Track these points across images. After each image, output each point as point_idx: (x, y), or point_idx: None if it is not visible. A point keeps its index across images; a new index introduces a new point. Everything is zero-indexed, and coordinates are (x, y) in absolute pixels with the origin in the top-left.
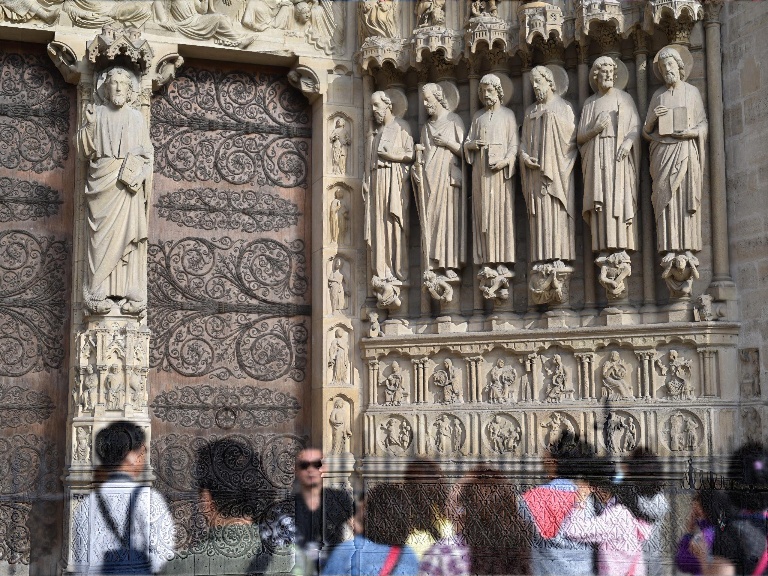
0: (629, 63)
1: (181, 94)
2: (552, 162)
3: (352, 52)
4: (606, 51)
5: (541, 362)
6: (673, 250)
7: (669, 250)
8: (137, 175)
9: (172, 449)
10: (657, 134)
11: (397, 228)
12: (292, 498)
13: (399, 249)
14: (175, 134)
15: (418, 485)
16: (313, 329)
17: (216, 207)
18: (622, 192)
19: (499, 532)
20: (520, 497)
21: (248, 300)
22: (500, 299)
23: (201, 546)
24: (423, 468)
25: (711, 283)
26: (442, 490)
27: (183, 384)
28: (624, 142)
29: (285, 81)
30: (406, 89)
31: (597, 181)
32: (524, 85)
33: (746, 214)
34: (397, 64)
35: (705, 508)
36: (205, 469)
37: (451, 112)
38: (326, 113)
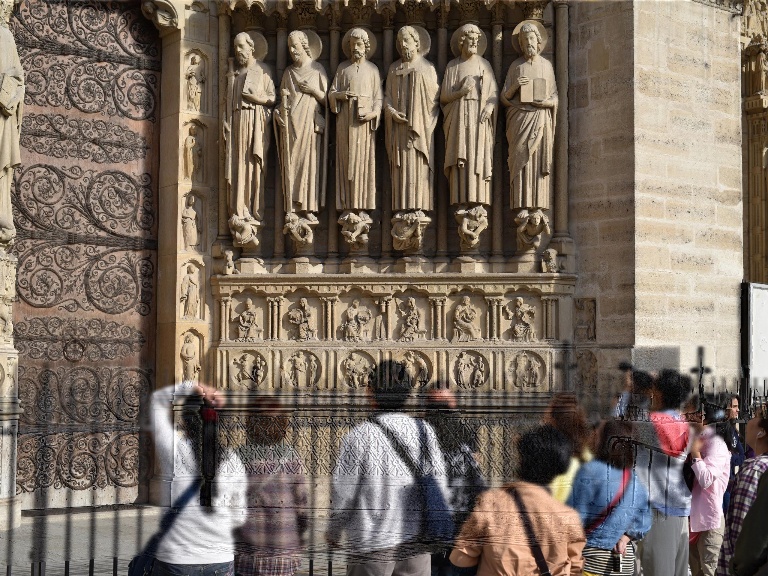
0: (485, 32)
1: (33, 14)
2: (419, 118)
3: None
4: (468, 19)
5: (395, 304)
6: (527, 207)
7: (523, 207)
8: (12, 97)
9: (20, 381)
10: (517, 101)
11: (258, 169)
12: (137, 431)
13: (259, 190)
14: (27, 55)
15: (272, 418)
16: (161, 264)
17: (67, 135)
18: (483, 151)
19: (352, 461)
20: (374, 429)
21: (97, 232)
22: (358, 243)
23: (48, 479)
24: (279, 402)
25: (553, 239)
26: (296, 422)
27: (32, 315)
28: (487, 106)
29: (136, 11)
30: (264, 33)
31: (462, 140)
32: (385, 42)
33: (588, 179)
34: (264, 8)
35: (545, 438)
36: (53, 402)
37: (314, 60)
38: (183, 48)
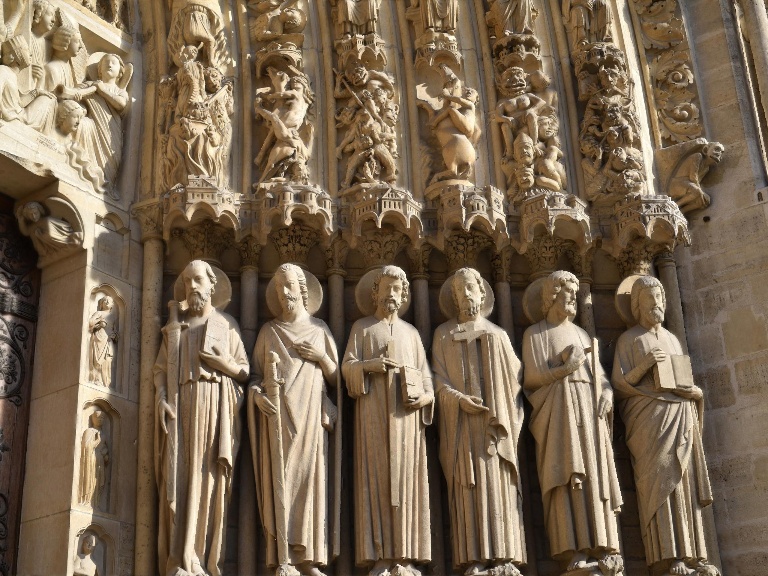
0: None
1: None
2: None
3: (130, 200)
4: (546, 269)
5: None
6: (685, 558)
7: (679, 557)
8: None
9: None
10: (650, 387)
11: (223, 487)
12: None
13: (222, 524)
14: None
15: None
16: None
17: None
18: None
19: None
20: None
21: None
22: None
23: None
24: None
25: None
26: None
27: None
28: (604, 392)
29: (3, 220)
30: None
31: (575, 443)
32: (418, 296)
33: (754, 516)
34: (239, 224)
35: None
36: None
37: (310, 315)
38: (90, 281)
